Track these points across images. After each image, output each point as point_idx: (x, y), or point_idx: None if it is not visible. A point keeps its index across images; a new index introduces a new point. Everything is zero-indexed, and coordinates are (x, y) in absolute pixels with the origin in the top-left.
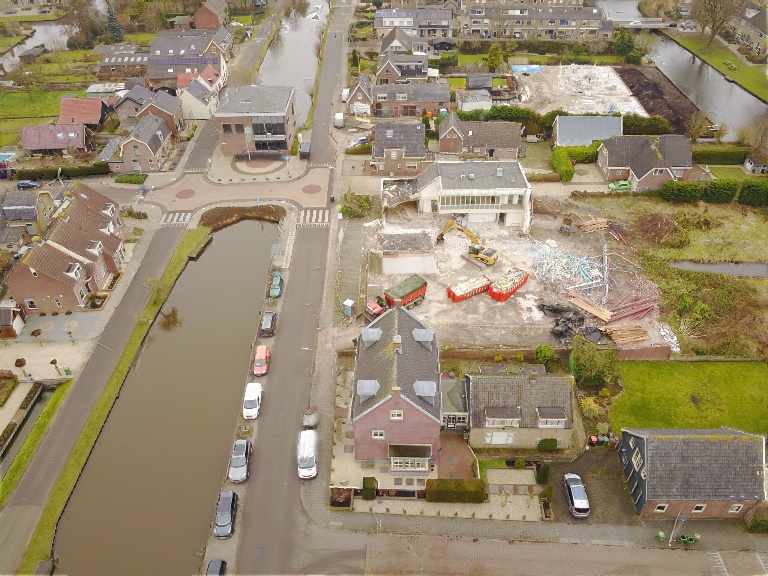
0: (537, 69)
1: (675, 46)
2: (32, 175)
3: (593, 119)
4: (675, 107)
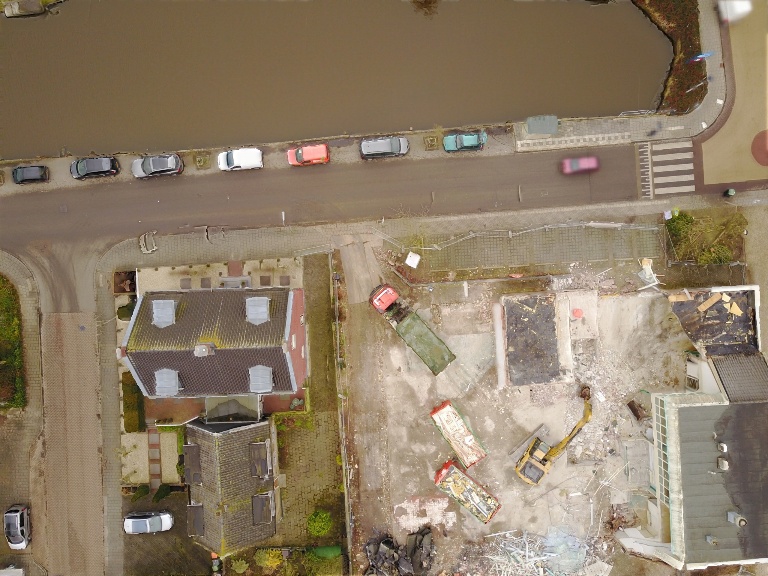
0: None
1: None
2: None
3: None
4: None
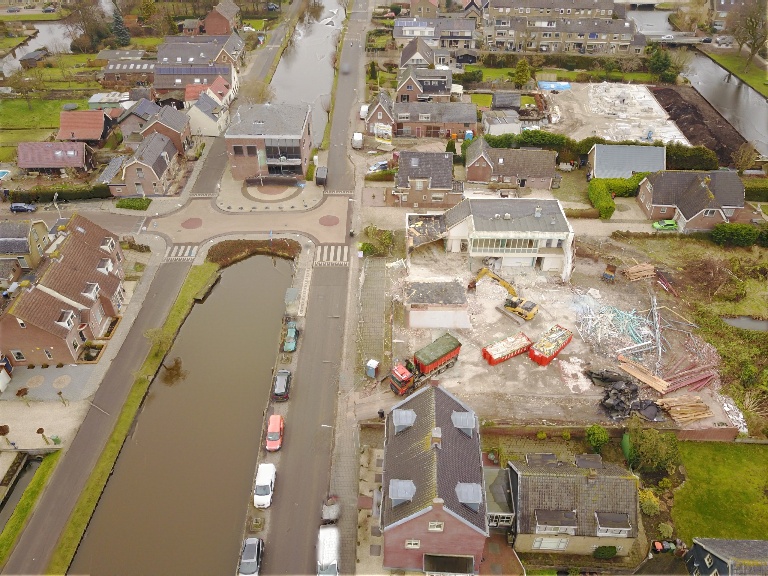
0: (566, 86)
1: (710, 63)
2: (27, 197)
3: (634, 149)
4: (717, 133)
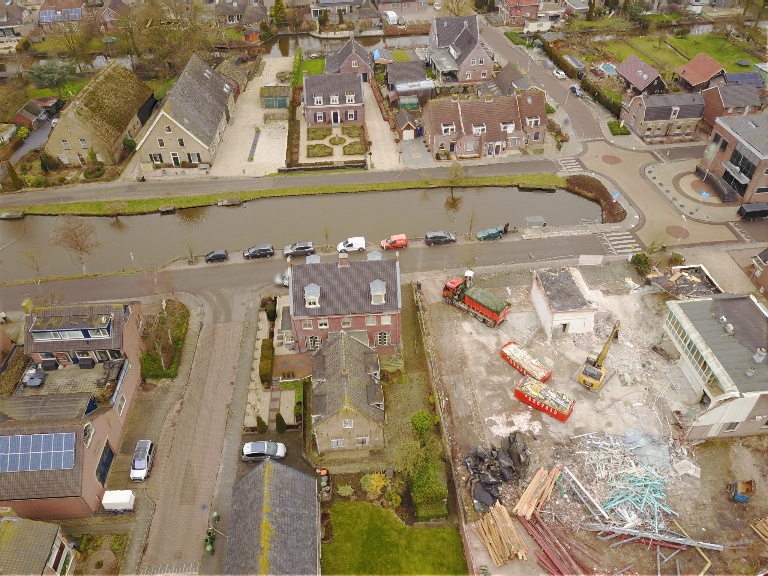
0: None
1: None
2: None
3: None
4: None
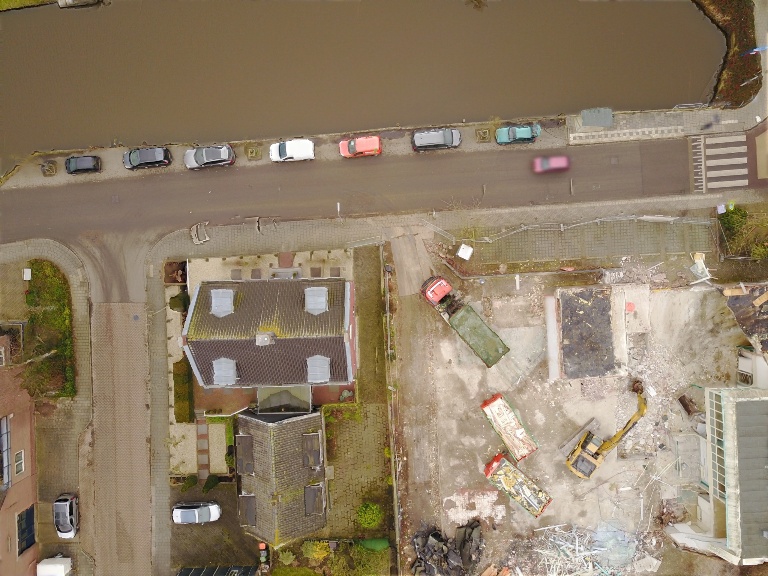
0: None
1: None
2: None
3: None
4: None
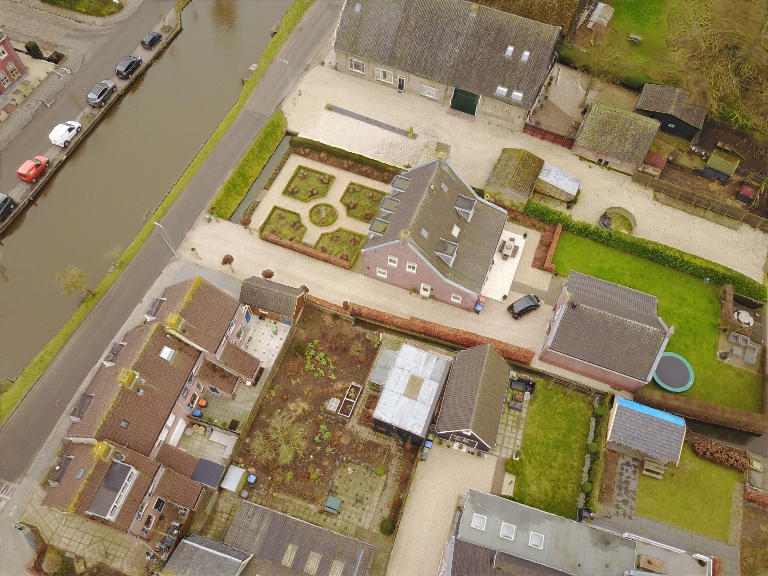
0: None
1: None
2: None
3: None
4: None
